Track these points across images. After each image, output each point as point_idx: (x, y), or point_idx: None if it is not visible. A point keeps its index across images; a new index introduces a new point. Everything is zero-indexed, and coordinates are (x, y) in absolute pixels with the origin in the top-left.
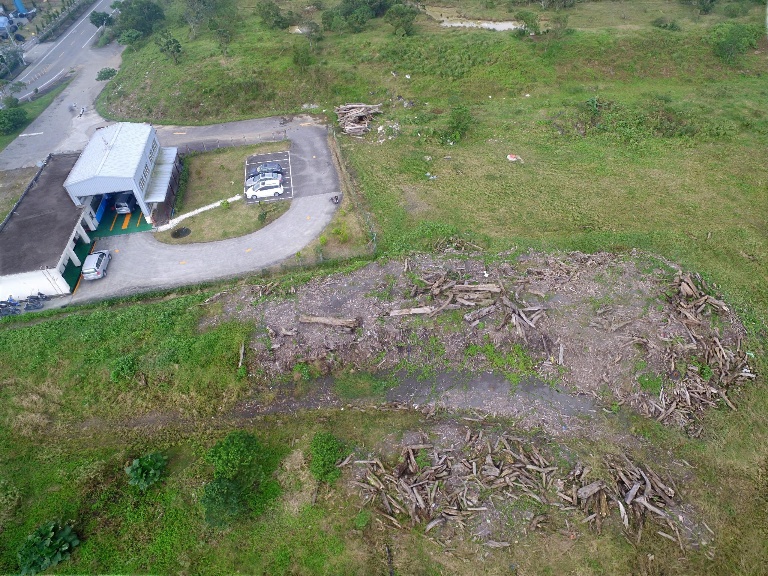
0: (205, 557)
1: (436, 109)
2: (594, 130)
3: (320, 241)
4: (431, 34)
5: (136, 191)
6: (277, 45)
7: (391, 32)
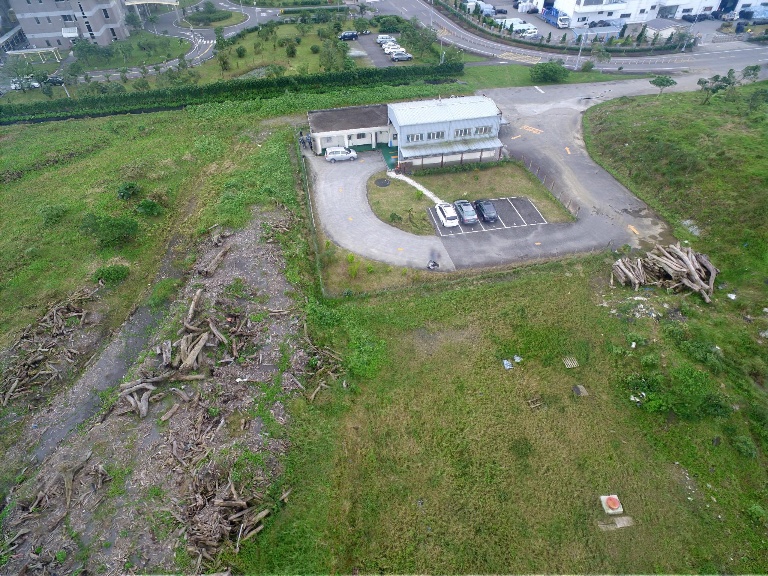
0: None
1: None
2: None
3: None
4: None
5: (399, 137)
6: None
7: None
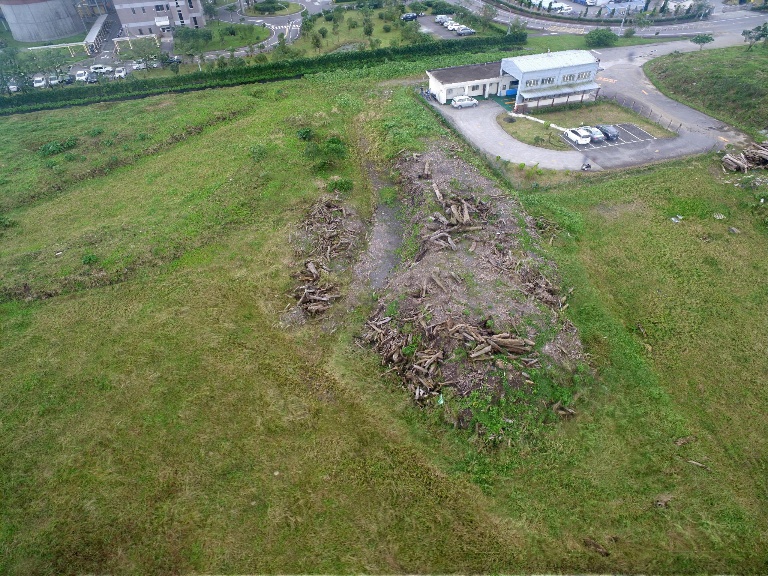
0: None
1: None
2: None
3: (520, 164)
4: None
5: (520, 82)
6: None
7: None
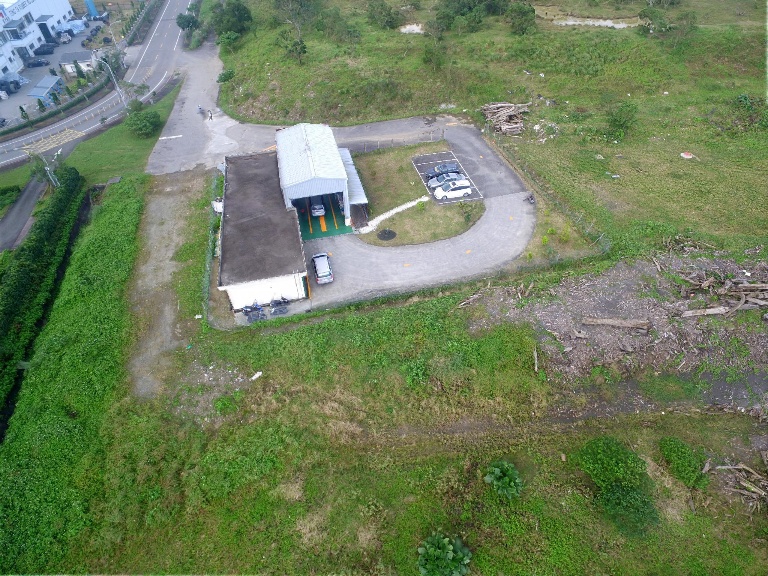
0: (614, 569)
1: (579, 107)
2: (756, 127)
3: (543, 241)
4: (553, 32)
5: (346, 193)
6: (399, 45)
7: (509, 31)
